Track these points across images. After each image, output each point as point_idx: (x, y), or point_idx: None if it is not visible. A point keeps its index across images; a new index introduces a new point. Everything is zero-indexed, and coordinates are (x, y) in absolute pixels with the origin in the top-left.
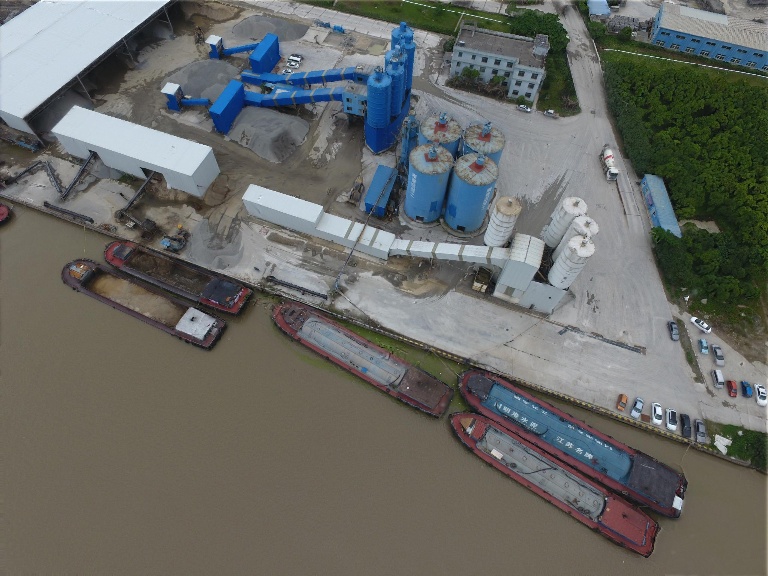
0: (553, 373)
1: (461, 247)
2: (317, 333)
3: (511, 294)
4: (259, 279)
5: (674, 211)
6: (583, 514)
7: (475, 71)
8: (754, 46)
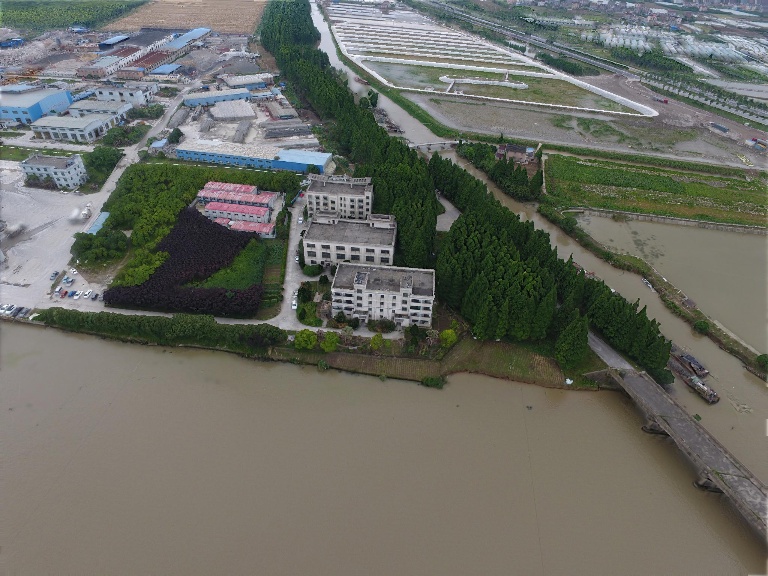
0: None
1: None
2: None
3: None
4: None
5: None
6: None
7: (32, 176)
8: (224, 153)
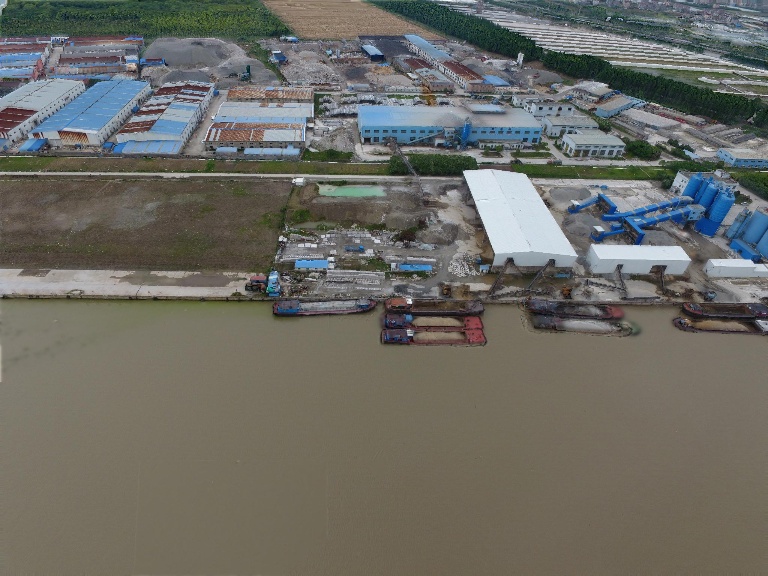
0: None
1: None
2: None
3: None
4: None
5: None
6: None
7: None
8: None
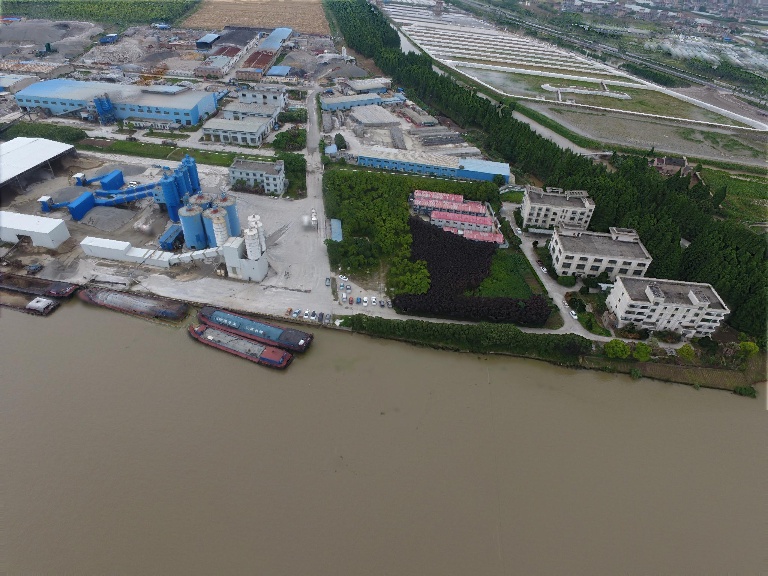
0: (255, 305)
1: (205, 250)
2: (115, 299)
3: (236, 272)
4: (85, 282)
5: (342, 233)
6: (253, 356)
7: (242, 180)
8: (408, 161)
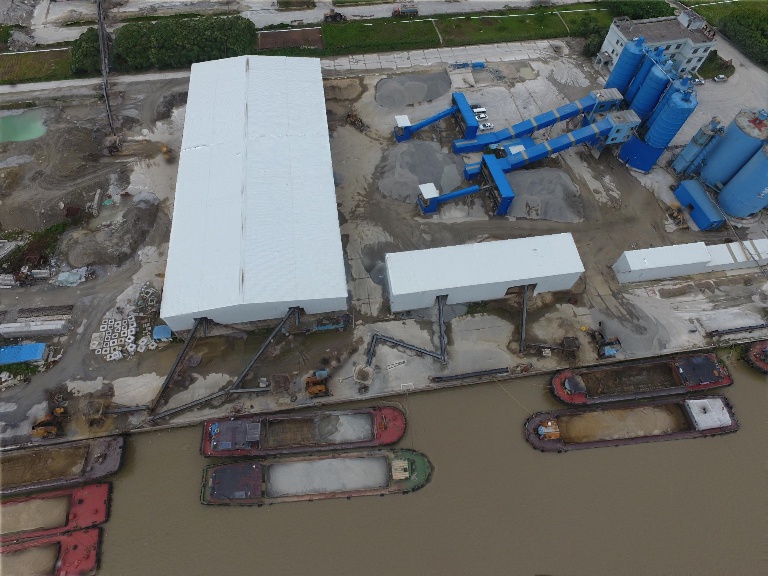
0: None
1: None
2: None
3: None
4: (703, 340)
5: None
6: None
7: None
8: None
